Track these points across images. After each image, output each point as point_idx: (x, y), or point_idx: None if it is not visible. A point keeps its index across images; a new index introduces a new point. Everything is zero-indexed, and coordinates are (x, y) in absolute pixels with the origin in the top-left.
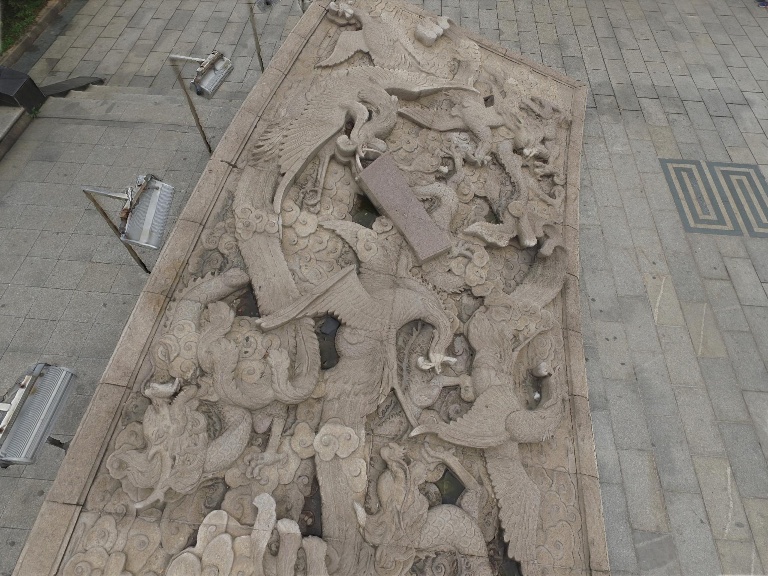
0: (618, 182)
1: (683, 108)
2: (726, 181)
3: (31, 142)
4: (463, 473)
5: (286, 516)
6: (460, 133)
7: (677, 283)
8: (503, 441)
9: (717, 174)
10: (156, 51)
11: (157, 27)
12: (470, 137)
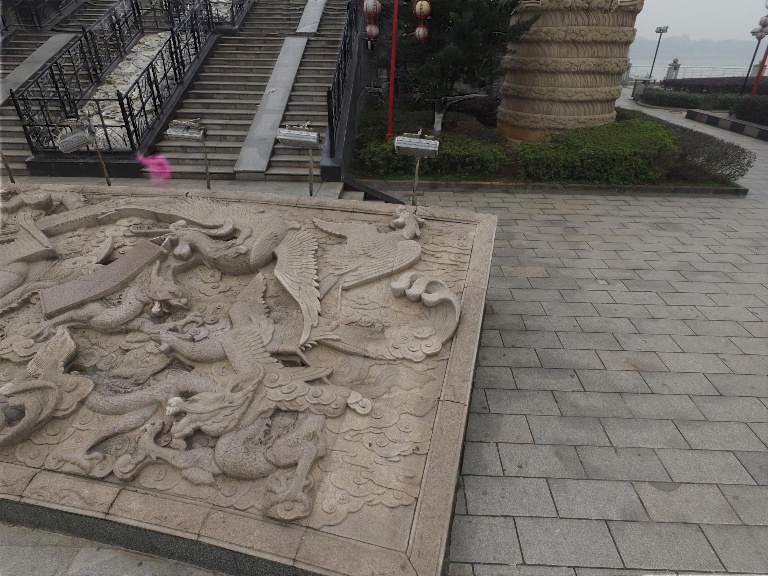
0: None
1: None
2: None
3: (298, 184)
4: None
5: None
6: None
7: None
8: None
9: None
10: None
11: None
12: None
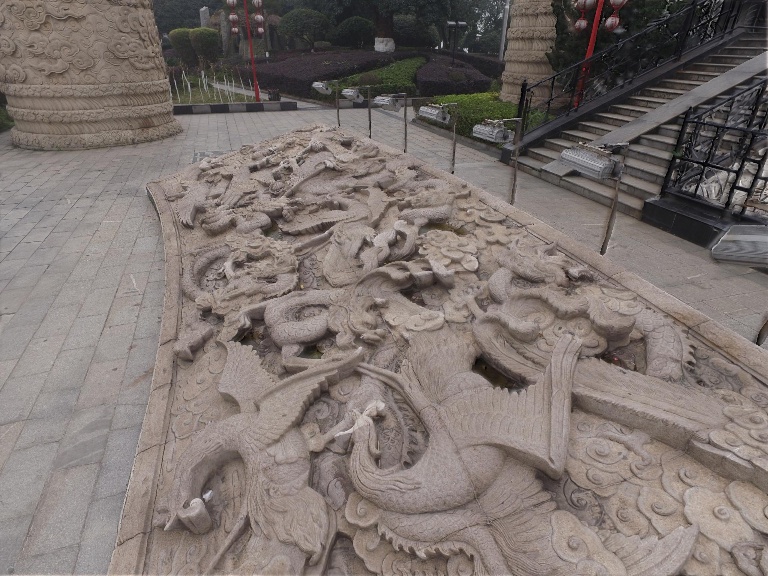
0: None
1: None
2: None
3: None
4: (302, 360)
5: (432, 292)
6: None
7: None
8: (262, 392)
9: None
10: None
11: None
12: None
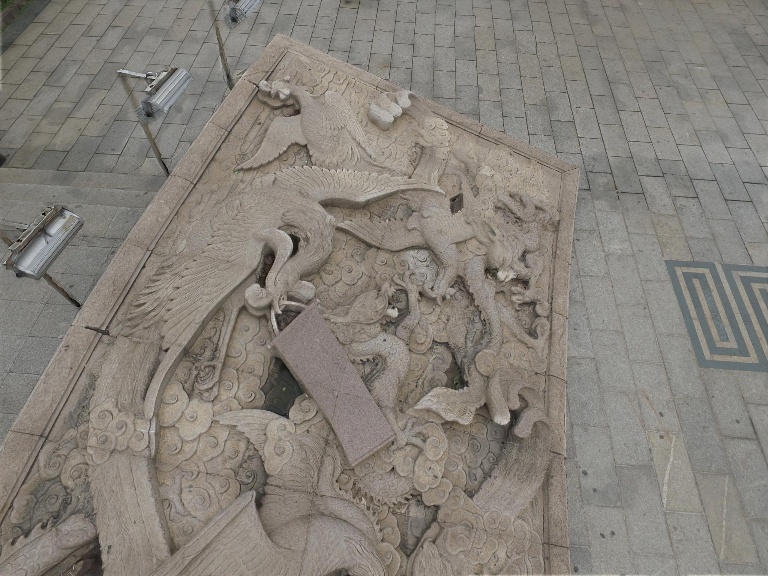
0: (616, 295)
1: (693, 190)
2: (747, 292)
3: None
4: None
5: None
6: (418, 251)
7: (691, 445)
8: None
9: (736, 282)
10: (74, 117)
11: (80, 85)
12: (430, 257)
